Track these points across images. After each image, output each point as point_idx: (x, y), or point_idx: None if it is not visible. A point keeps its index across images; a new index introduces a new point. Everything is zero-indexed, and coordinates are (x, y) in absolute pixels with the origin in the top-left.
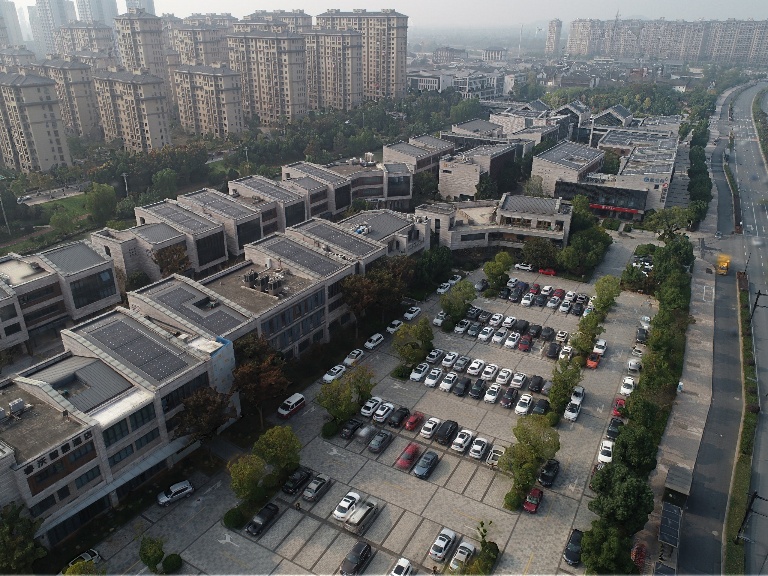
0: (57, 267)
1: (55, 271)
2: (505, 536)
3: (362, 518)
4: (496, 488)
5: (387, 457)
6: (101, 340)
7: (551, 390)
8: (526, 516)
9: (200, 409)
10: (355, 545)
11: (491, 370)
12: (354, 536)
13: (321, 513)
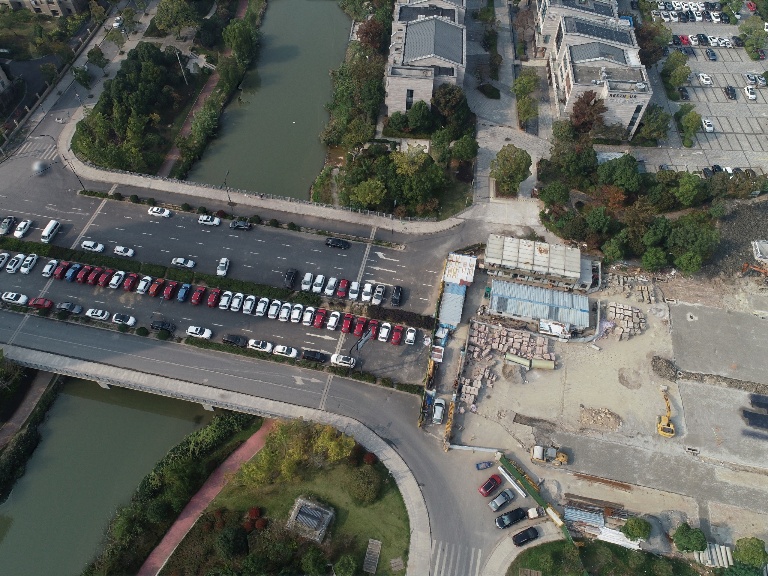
0: (455, 4)
1: (456, 7)
2: (763, 70)
3: (713, 81)
4: (742, 55)
5: (691, 58)
6: (585, 33)
7: (734, 5)
8: (762, 61)
9: (652, 52)
10: (729, 88)
11: (687, 5)
12: (718, 88)
13: (697, 85)
